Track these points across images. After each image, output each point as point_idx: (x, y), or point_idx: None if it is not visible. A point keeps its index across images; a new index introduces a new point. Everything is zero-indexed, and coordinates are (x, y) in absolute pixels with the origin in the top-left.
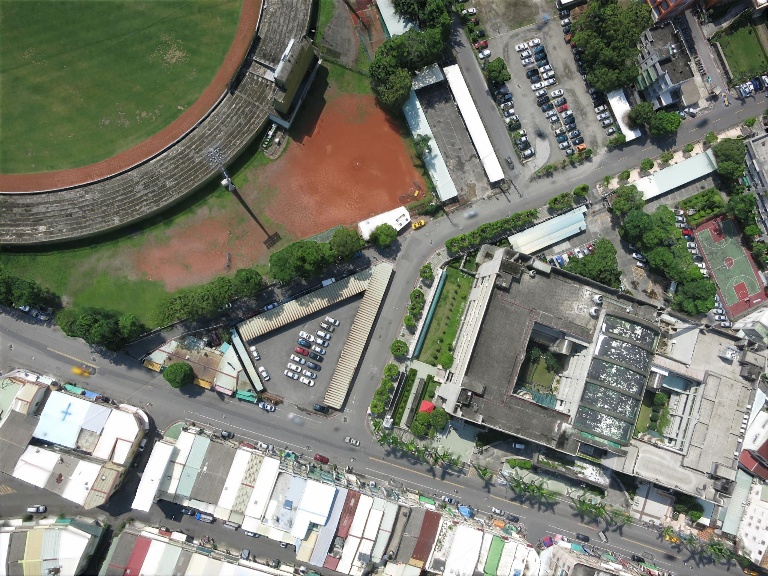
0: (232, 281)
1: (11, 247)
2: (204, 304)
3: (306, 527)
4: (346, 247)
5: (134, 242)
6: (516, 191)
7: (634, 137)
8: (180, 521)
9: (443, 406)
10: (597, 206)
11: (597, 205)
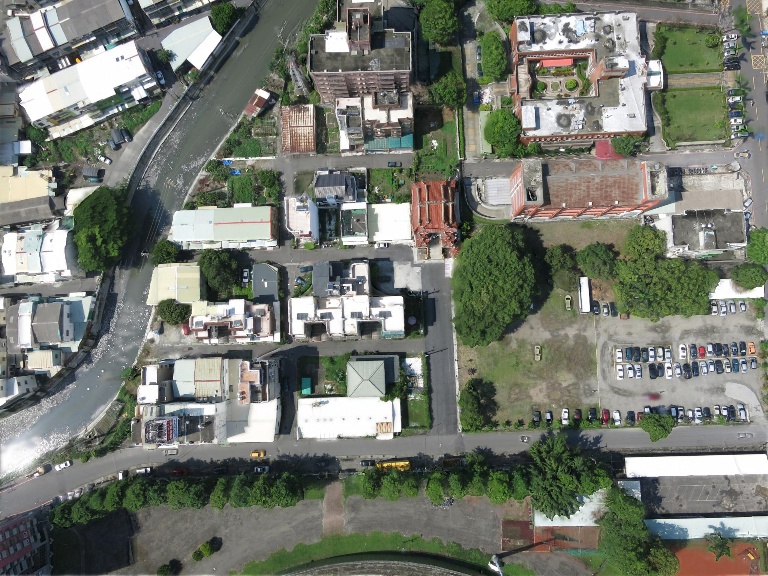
0: None
1: None
2: None
3: None
4: None
5: None
6: None
7: (762, 287)
8: None
9: None
10: None
11: None
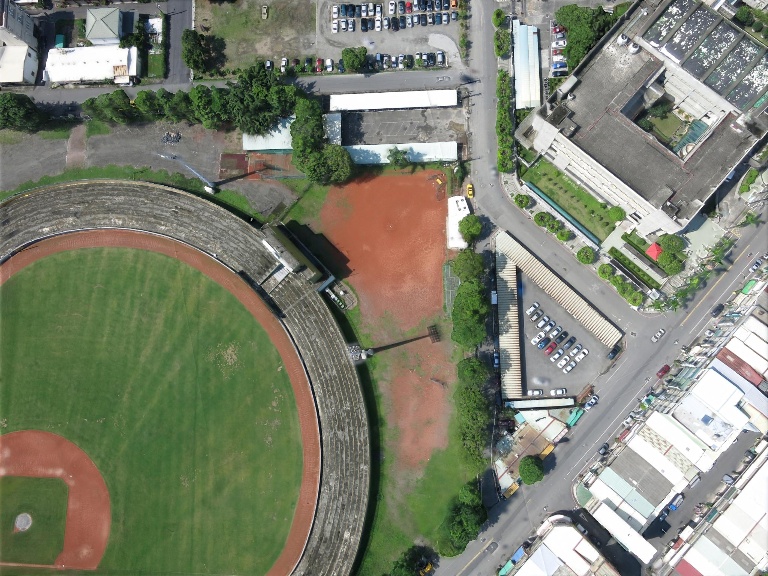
0: (466, 386)
1: (353, 569)
2: (480, 420)
3: (738, 412)
4: (476, 267)
5: (388, 460)
6: (472, 84)
7: None
8: (670, 526)
9: (659, 235)
10: (517, 8)
11: (516, 8)
